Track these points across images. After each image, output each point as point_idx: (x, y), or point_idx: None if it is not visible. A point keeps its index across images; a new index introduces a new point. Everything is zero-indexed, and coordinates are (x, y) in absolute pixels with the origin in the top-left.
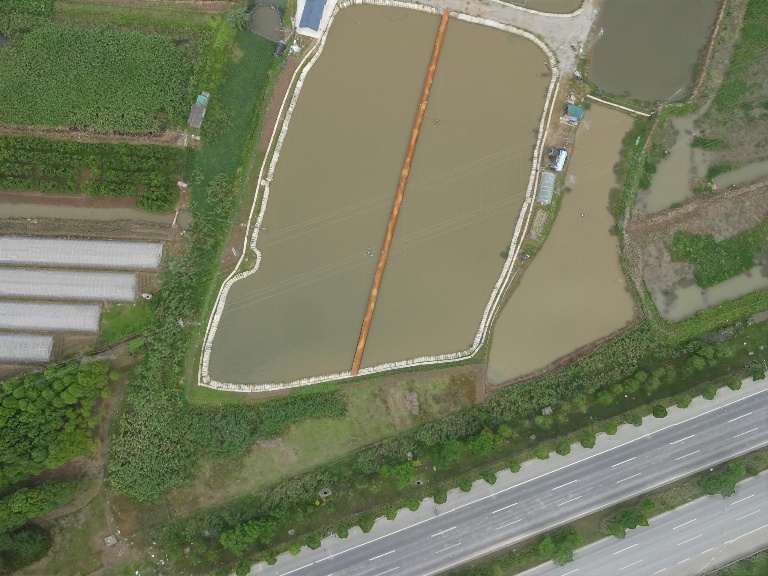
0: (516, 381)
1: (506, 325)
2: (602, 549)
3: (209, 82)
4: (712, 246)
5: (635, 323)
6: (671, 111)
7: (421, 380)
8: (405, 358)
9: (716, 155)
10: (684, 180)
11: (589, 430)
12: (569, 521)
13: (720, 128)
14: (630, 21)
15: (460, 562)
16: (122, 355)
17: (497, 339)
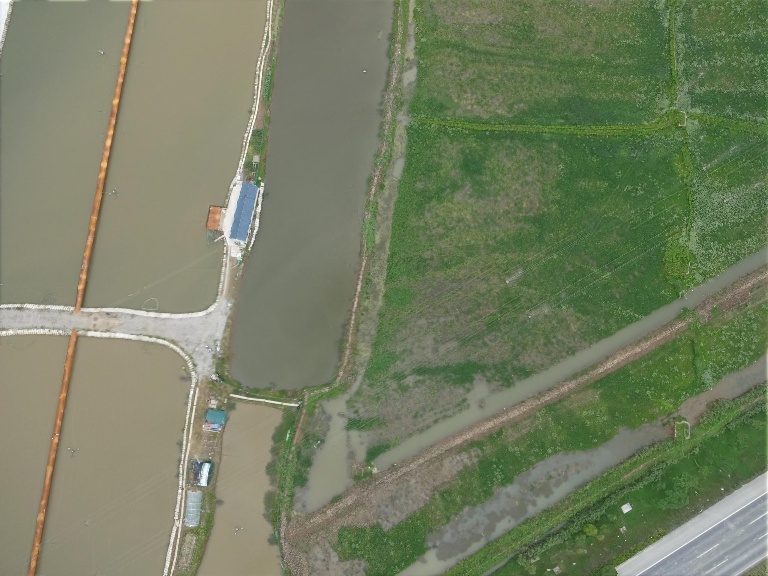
0: None
1: None
2: None
3: None
4: (379, 537)
5: None
6: (319, 397)
7: None
8: None
9: (373, 435)
10: (343, 468)
11: None
12: None
13: (374, 405)
14: (268, 307)
15: None
16: None
17: None
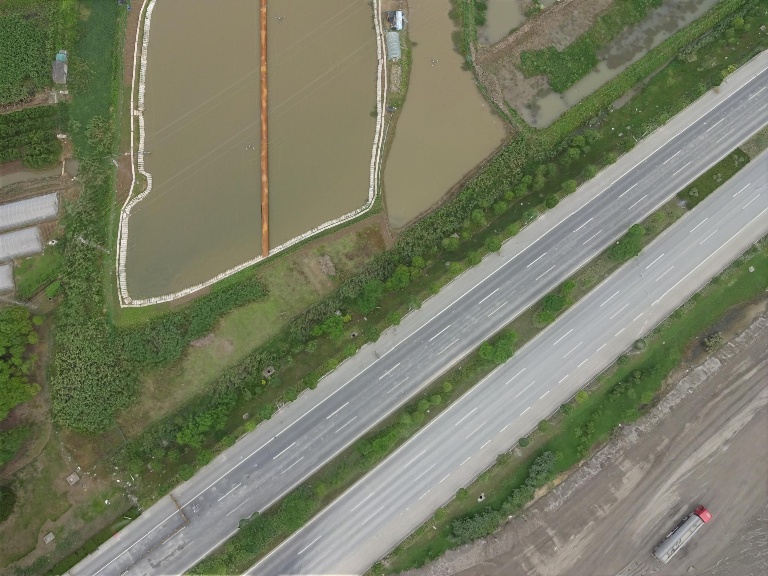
0: (417, 219)
1: (394, 174)
2: (541, 343)
3: None
4: (556, 55)
5: (509, 138)
6: None
7: (330, 244)
8: (309, 228)
9: None
10: (514, 8)
11: None
12: (503, 327)
13: None
14: None
15: (413, 394)
16: (42, 303)
17: (389, 188)
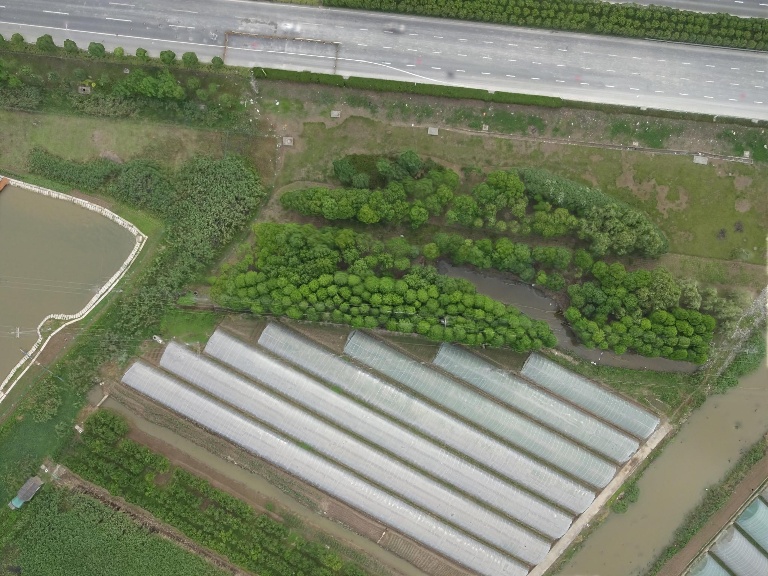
0: None
1: None
2: None
3: (6, 517)
4: None
5: None
6: None
7: None
8: None
9: None
10: None
11: None
12: None
13: None
14: None
15: None
16: (206, 297)
17: None
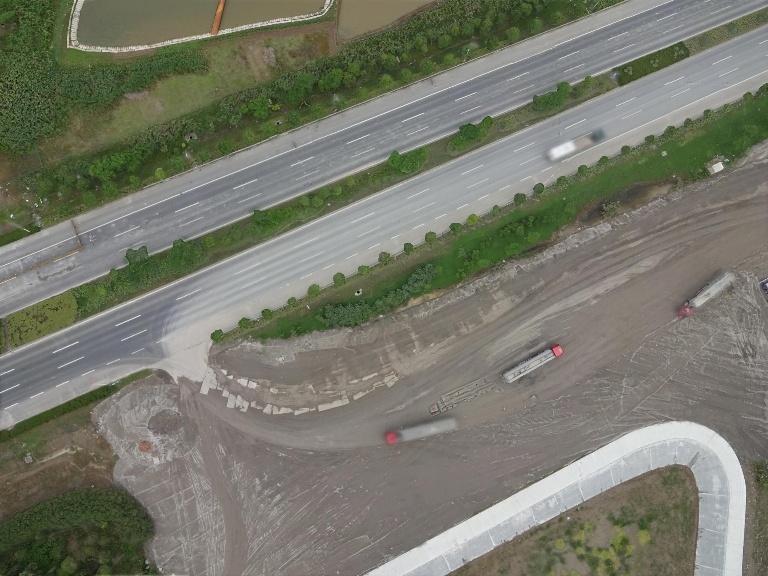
0: (365, 35)
1: None
2: (450, 171)
3: None
4: None
5: None
6: None
7: (277, 39)
8: (262, 20)
9: None
10: None
11: None
12: (418, 147)
13: None
14: None
15: (319, 186)
16: None
17: (346, 2)
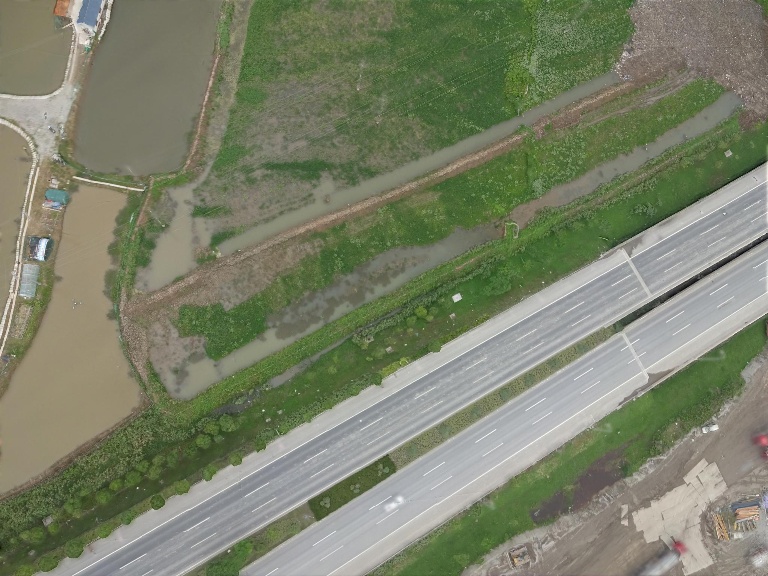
0: (8, 494)
1: None
2: None
3: None
4: (220, 316)
5: (140, 409)
6: (165, 183)
7: None
8: None
9: (219, 222)
10: (187, 252)
11: (89, 534)
12: None
13: (221, 194)
14: (117, 96)
15: None
16: None
17: None
